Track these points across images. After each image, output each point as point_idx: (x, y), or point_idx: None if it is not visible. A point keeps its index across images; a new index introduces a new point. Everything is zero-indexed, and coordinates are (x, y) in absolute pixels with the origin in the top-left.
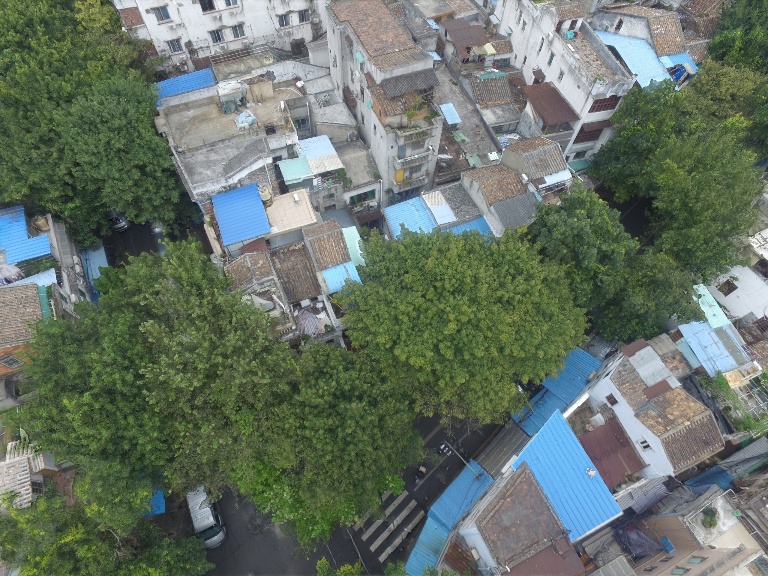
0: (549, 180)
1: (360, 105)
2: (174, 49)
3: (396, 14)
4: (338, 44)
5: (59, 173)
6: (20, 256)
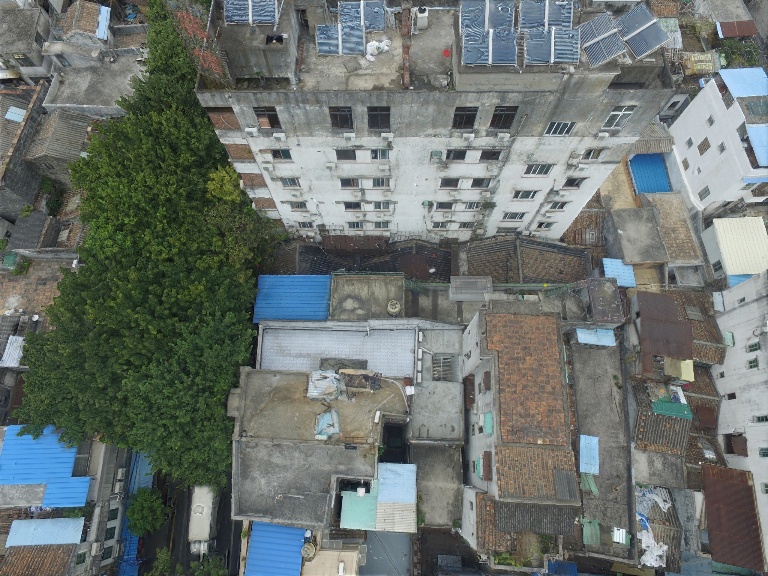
0: None
1: (475, 421)
2: (304, 226)
3: (590, 223)
4: (475, 362)
5: (116, 428)
6: (56, 501)
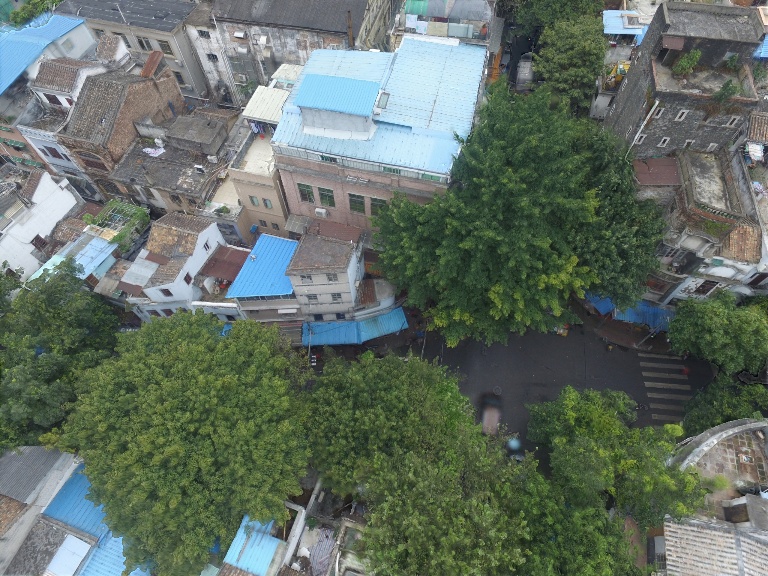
0: None
1: None
2: None
3: None
4: None
5: None
6: None
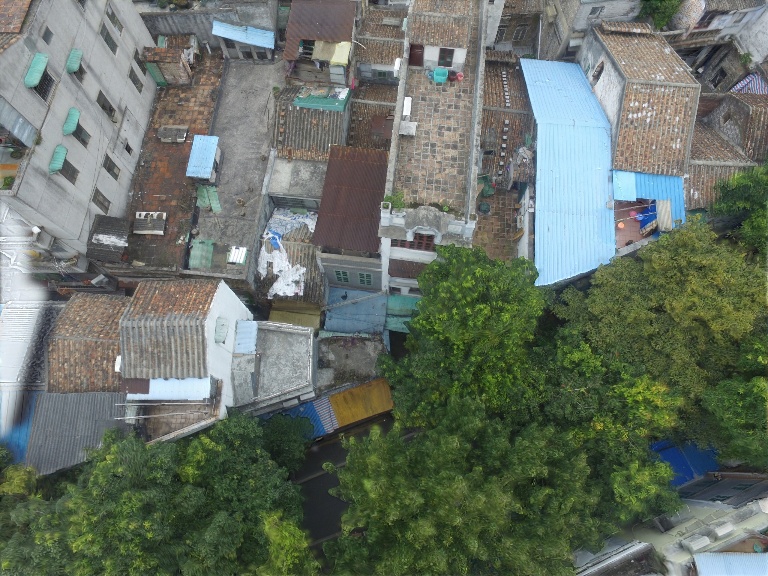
0: (156, 389)
1: None
2: None
3: None
4: None
5: None
6: None
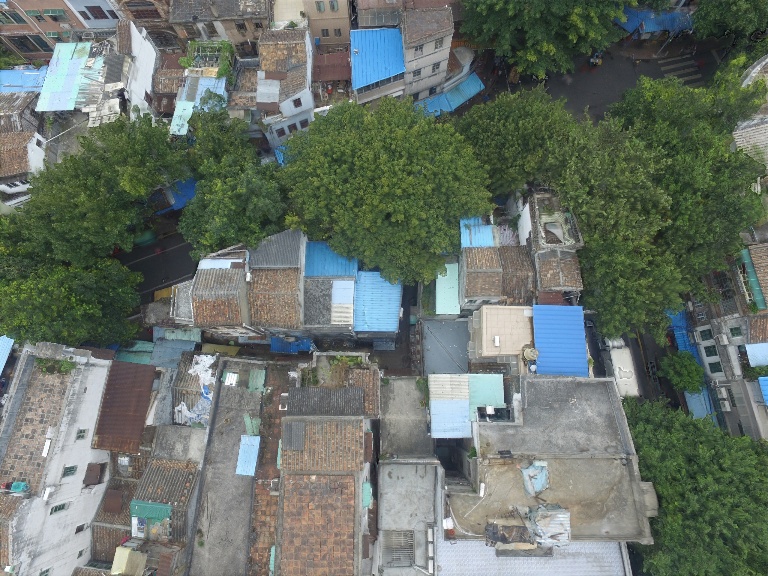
0: (227, 264)
1: None
2: None
3: None
4: None
5: None
6: None
